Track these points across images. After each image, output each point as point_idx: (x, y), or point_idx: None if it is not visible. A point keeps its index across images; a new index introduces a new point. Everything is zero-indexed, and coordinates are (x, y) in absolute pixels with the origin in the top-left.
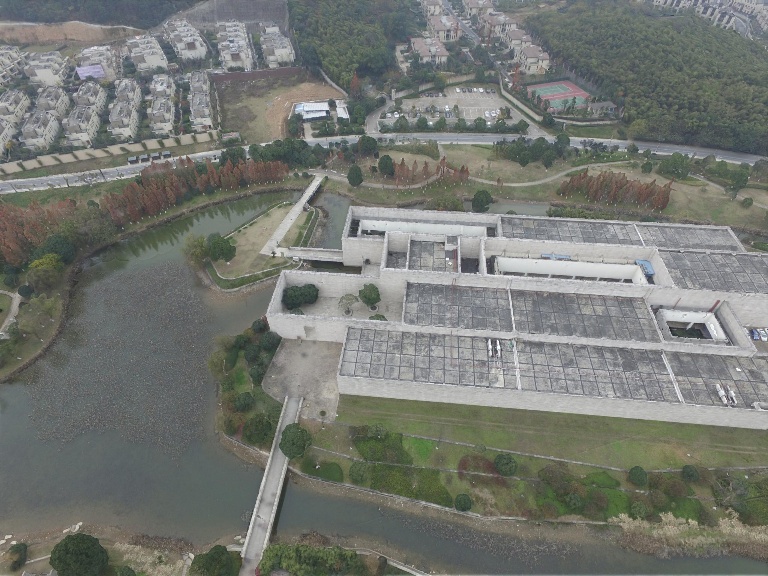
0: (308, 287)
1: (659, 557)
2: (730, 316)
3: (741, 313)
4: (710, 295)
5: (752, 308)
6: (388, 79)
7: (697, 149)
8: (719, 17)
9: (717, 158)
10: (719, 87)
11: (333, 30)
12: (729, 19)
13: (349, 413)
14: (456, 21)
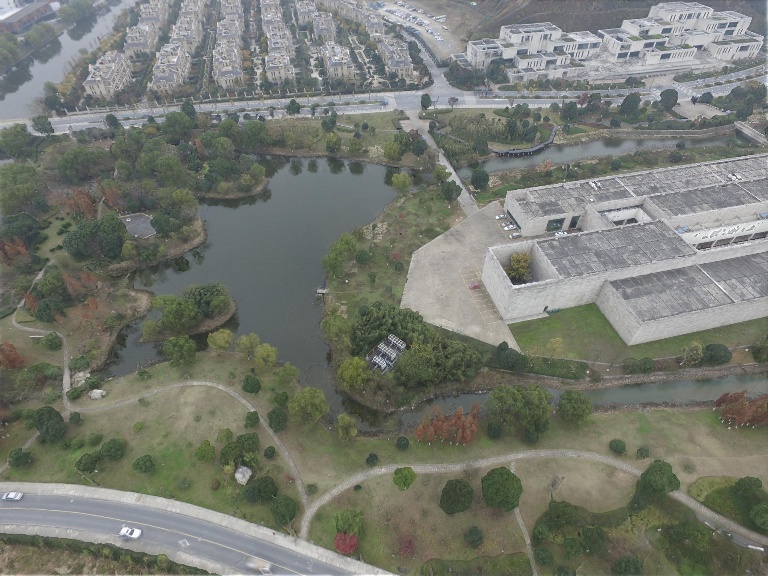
0: None
1: (591, 156)
2: None
3: None
4: None
5: None
6: None
7: None
8: None
9: None
10: None
11: None
12: None
13: None
14: None
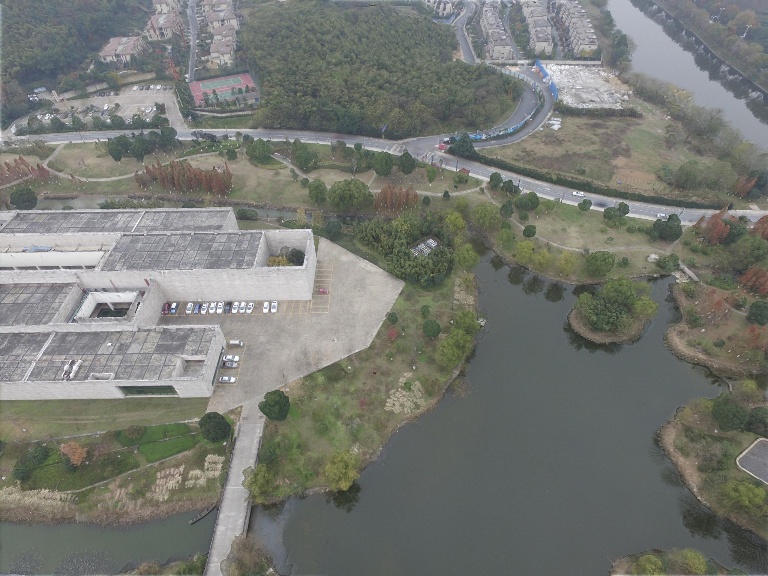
0: None
1: None
2: None
3: (180, 289)
4: (132, 275)
5: (183, 284)
6: (61, 81)
7: (315, 134)
8: (436, 5)
9: (325, 141)
10: (351, 73)
11: (4, 33)
12: (444, 6)
13: None
14: (172, 19)
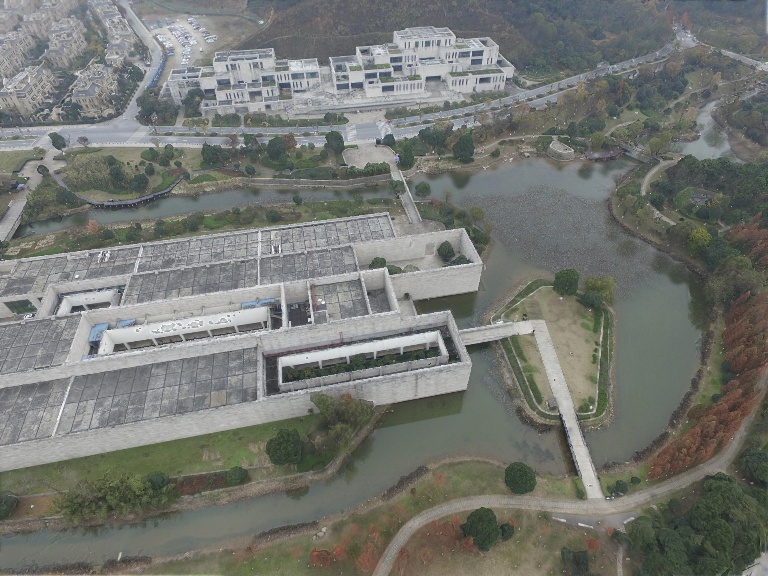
0: None
1: None
2: None
3: None
4: None
5: None
6: None
7: None
8: None
9: None
10: None
11: None
12: None
13: None
14: None
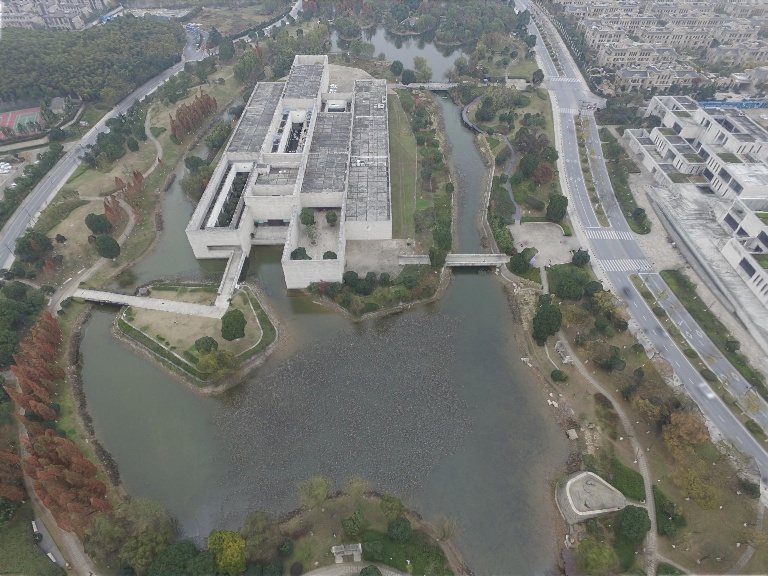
0: (299, 250)
1: (452, 146)
2: (330, 95)
3: None
4: None
5: None
6: None
7: (145, 86)
8: None
9: None
10: None
11: None
12: None
13: (406, 233)
14: None
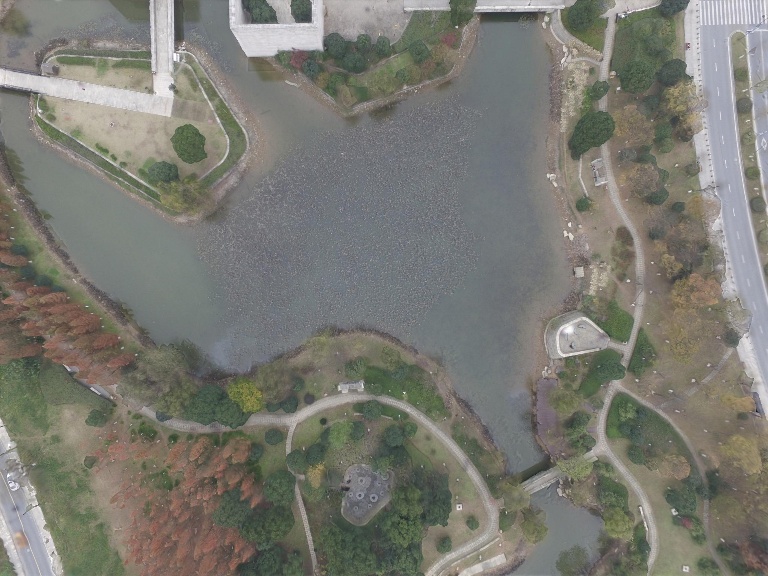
0: None
1: None
2: None
3: None
4: None
5: None
6: None
7: None
8: None
9: None
10: None
11: None
12: None
13: None
14: None
